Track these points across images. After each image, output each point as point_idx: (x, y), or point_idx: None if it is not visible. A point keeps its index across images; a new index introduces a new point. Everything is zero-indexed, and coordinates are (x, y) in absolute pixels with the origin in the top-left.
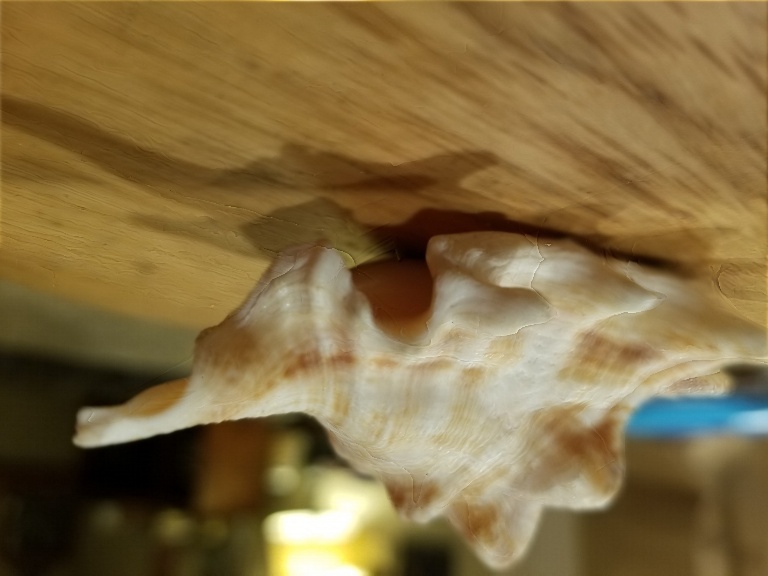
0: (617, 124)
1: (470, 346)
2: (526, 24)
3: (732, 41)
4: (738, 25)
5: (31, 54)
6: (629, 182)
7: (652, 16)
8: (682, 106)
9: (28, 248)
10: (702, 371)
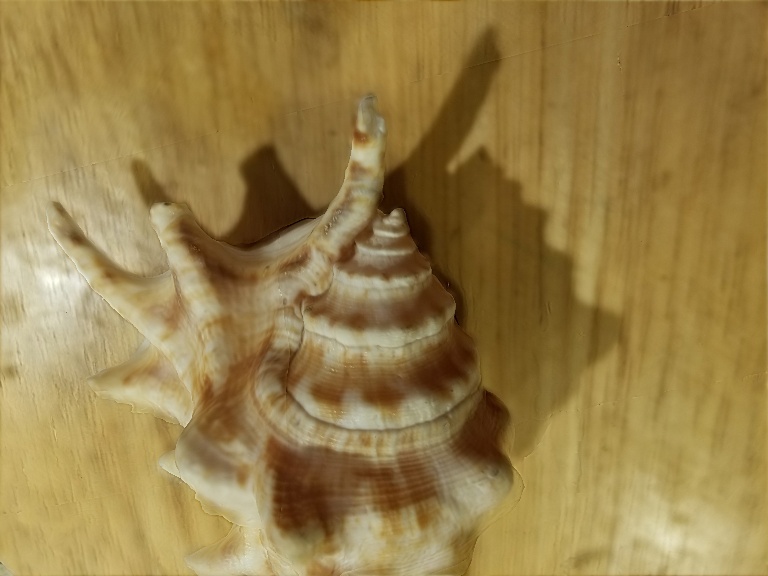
0: (164, 533)
1: (245, 569)
2: None
3: (114, 553)
4: (111, 559)
5: None
6: (180, 482)
7: (132, 575)
8: (138, 529)
9: None
10: (157, 346)
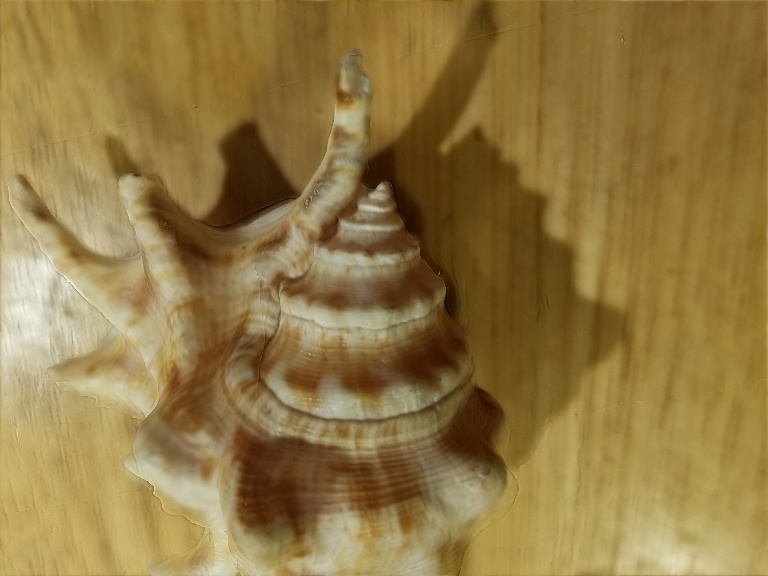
0: (131, 545)
1: None
2: None
3: (77, 566)
4: (74, 572)
5: None
6: (150, 489)
7: None
8: (103, 540)
9: None
10: (124, 333)
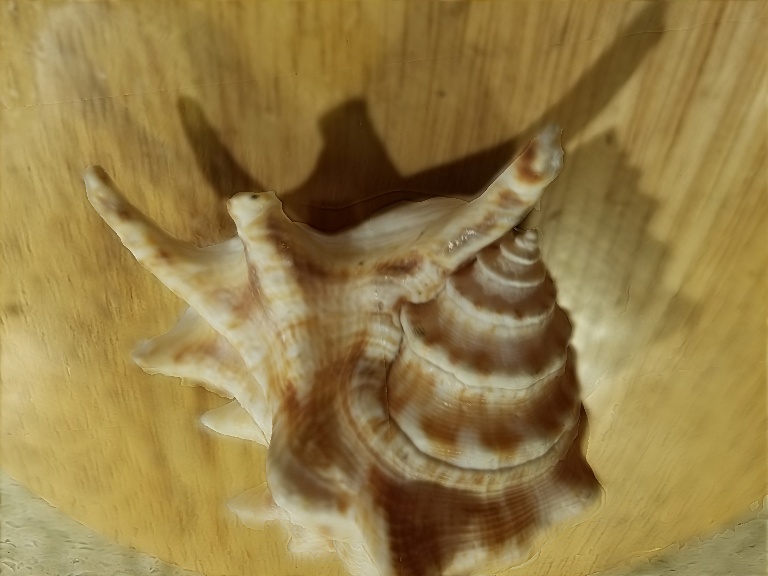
0: (187, 457)
1: None
2: (186, 502)
3: (132, 470)
4: (128, 475)
5: (337, 563)
6: None
7: None
8: (159, 453)
9: (641, 536)
10: (221, 332)
